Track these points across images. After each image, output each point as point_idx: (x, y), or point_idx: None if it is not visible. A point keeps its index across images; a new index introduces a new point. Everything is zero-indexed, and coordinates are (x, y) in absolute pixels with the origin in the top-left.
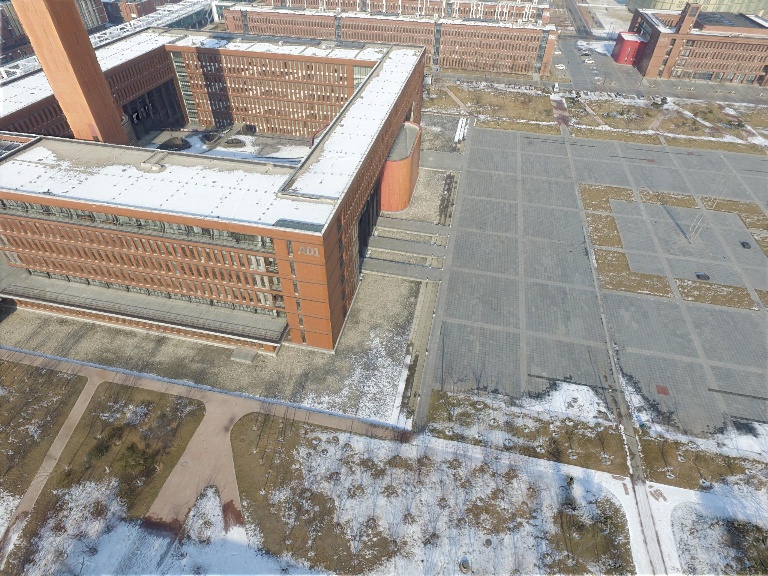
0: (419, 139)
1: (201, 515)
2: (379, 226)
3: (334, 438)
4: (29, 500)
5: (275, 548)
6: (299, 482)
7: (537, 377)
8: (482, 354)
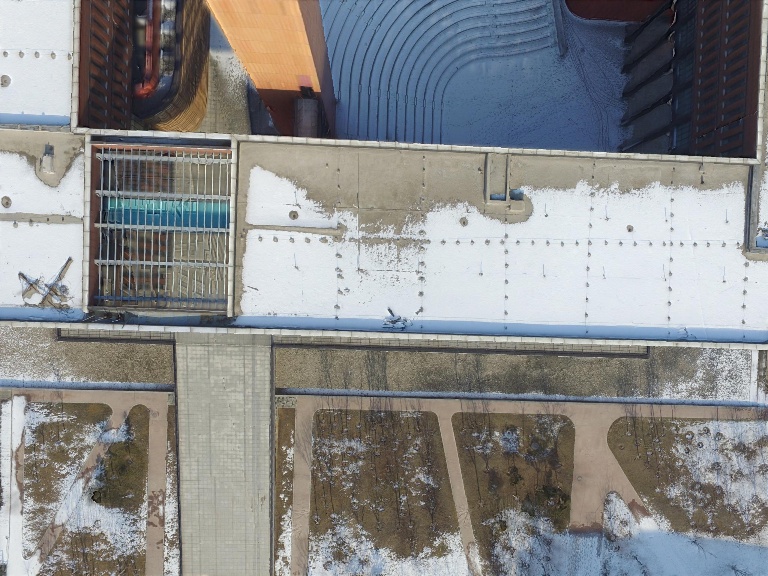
0: None
1: (616, 518)
2: None
3: (704, 429)
4: (467, 534)
5: (682, 528)
6: (688, 477)
7: None
8: None
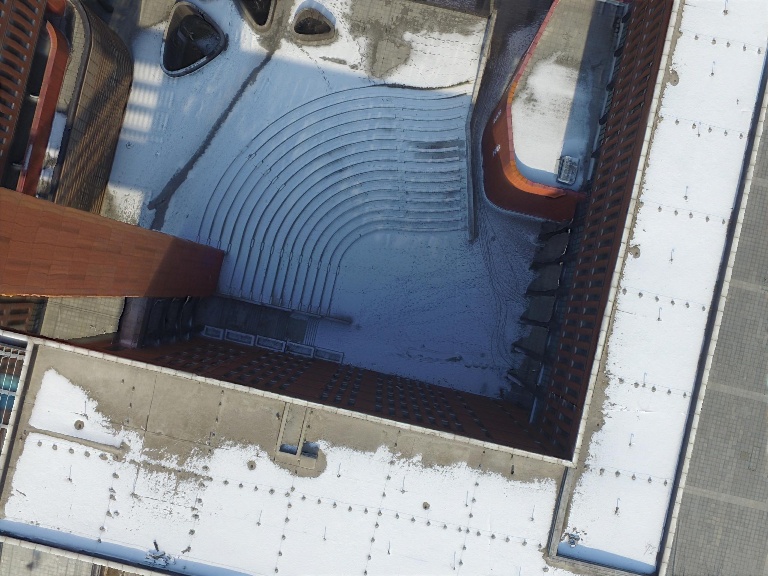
0: None
1: None
2: None
3: None
4: None
5: None
6: None
7: None
8: (723, 548)
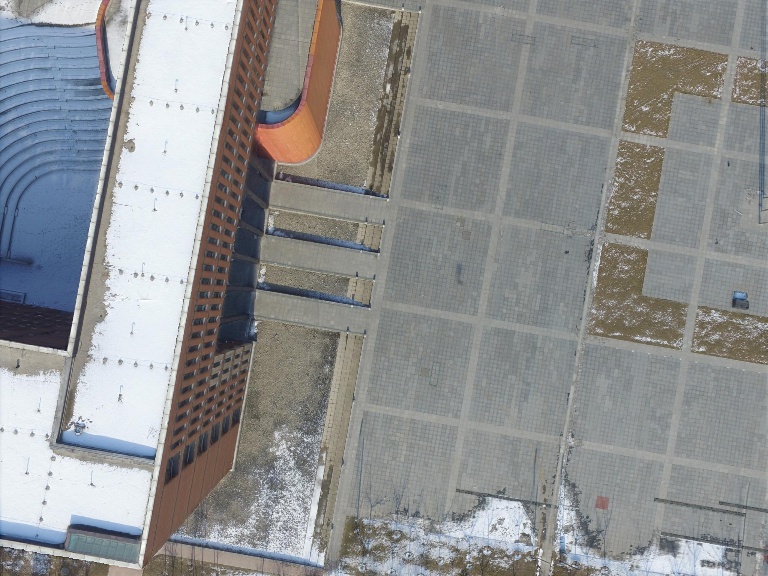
0: (324, 3)
1: None
2: (274, 207)
3: None
4: None
5: None
6: None
7: (466, 493)
8: (408, 463)
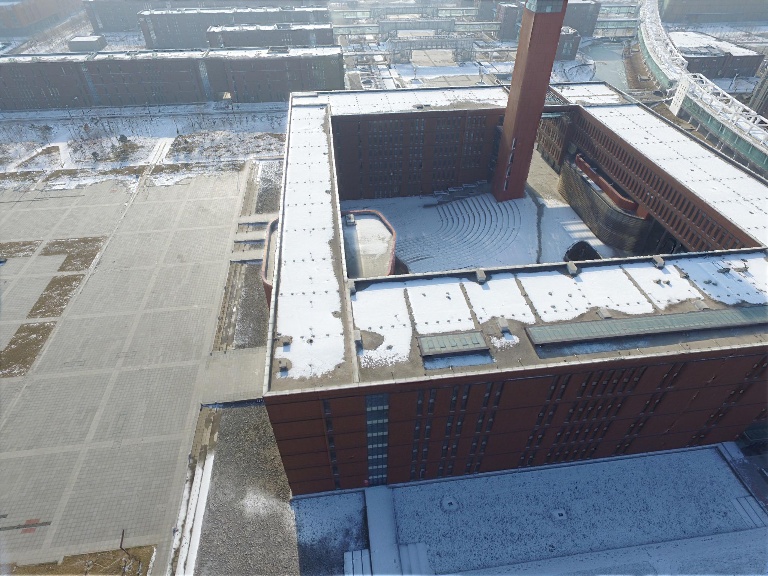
0: None
1: None
2: None
3: None
4: None
5: None
6: None
7: (185, 184)
8: None
